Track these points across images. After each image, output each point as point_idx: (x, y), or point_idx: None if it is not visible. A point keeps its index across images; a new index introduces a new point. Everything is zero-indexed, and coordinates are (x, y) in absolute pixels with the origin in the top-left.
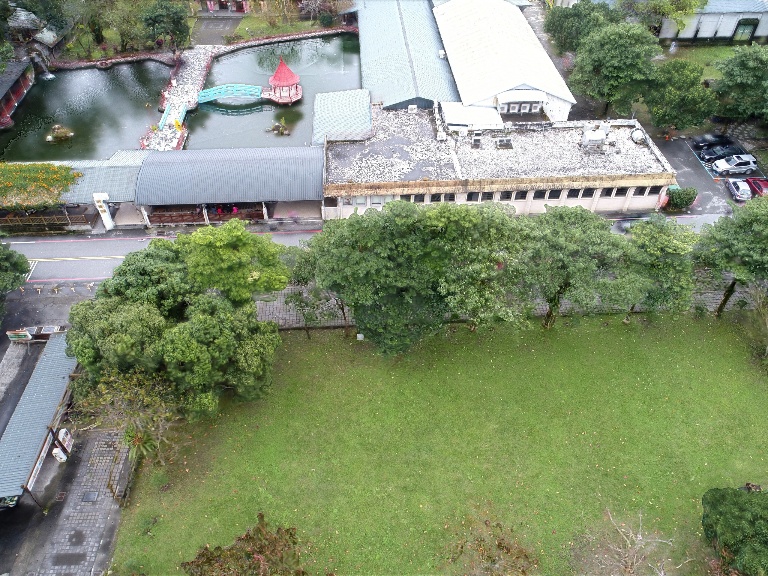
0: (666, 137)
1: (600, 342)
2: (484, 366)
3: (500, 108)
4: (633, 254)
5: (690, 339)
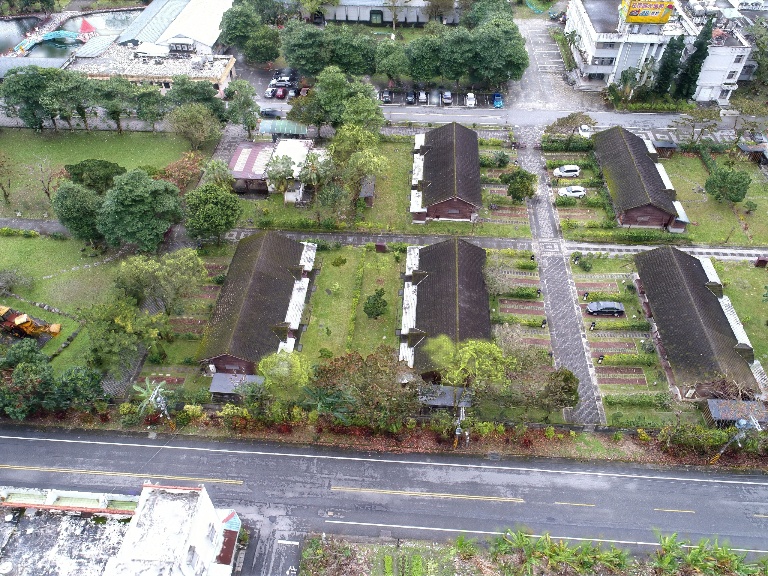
0: (266, 69)
1: (137, 140)
2: (81, 143)
3: (171, 47)
4: (125, 93)
5: (174, 141)
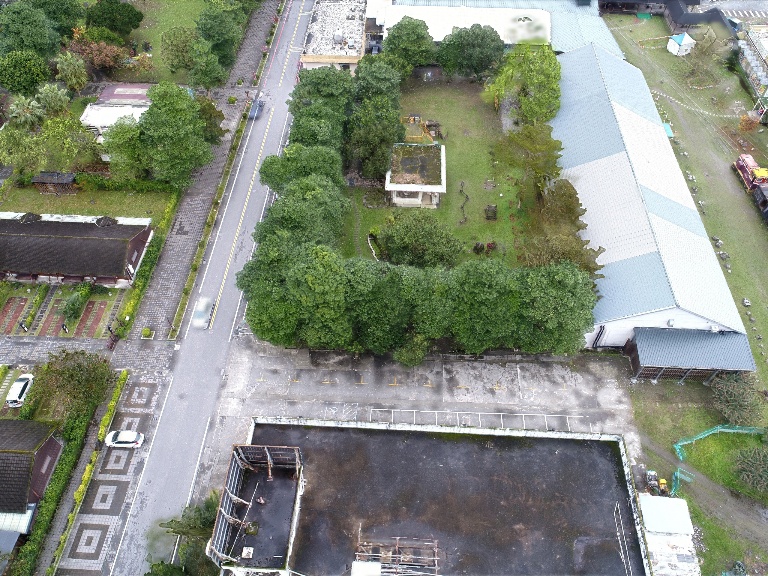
0: None
1: None
2: None
3: None
4: None
5: None
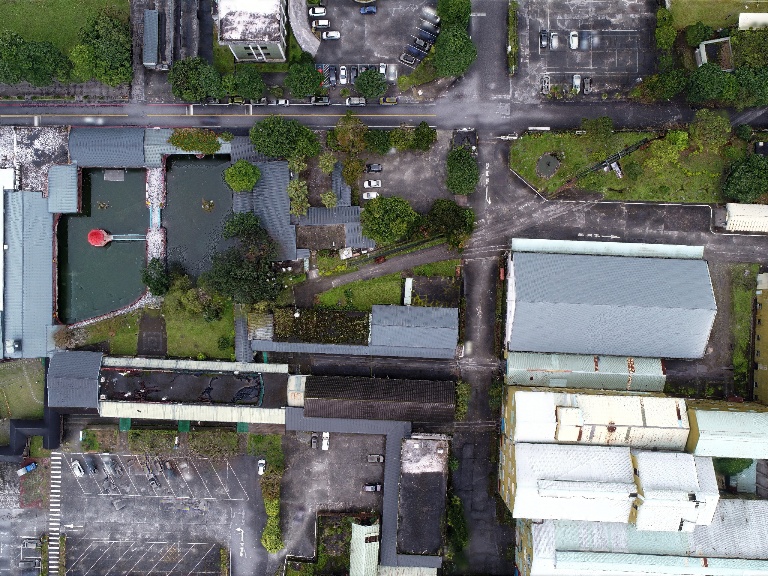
0: None
1: None
2: None
3: None
4: None
5: None
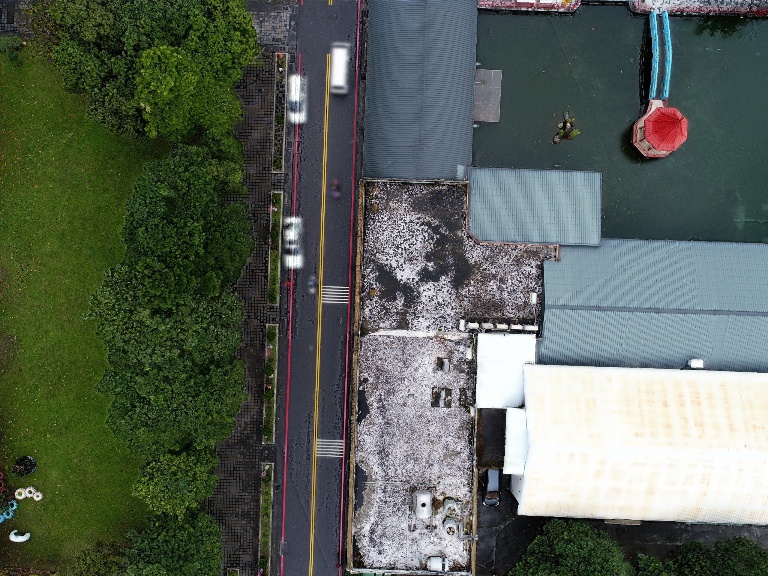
0: None
1: None
2: None
3: None
4: None
5: None
